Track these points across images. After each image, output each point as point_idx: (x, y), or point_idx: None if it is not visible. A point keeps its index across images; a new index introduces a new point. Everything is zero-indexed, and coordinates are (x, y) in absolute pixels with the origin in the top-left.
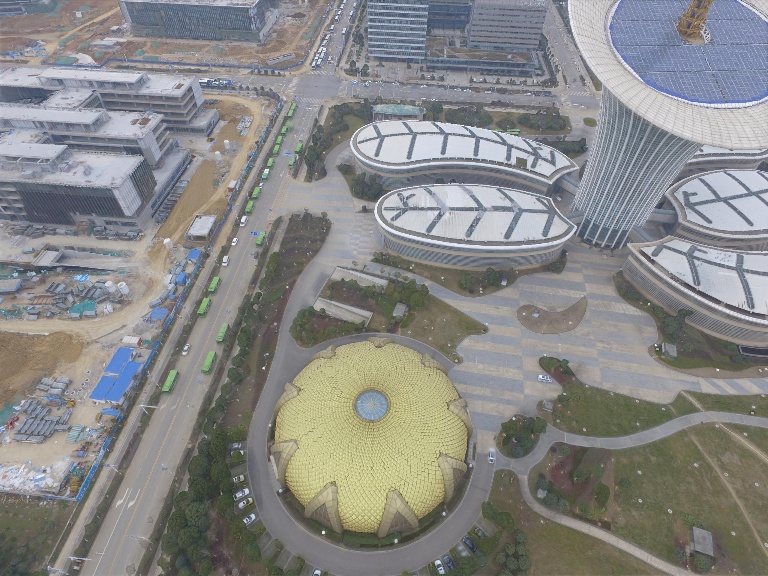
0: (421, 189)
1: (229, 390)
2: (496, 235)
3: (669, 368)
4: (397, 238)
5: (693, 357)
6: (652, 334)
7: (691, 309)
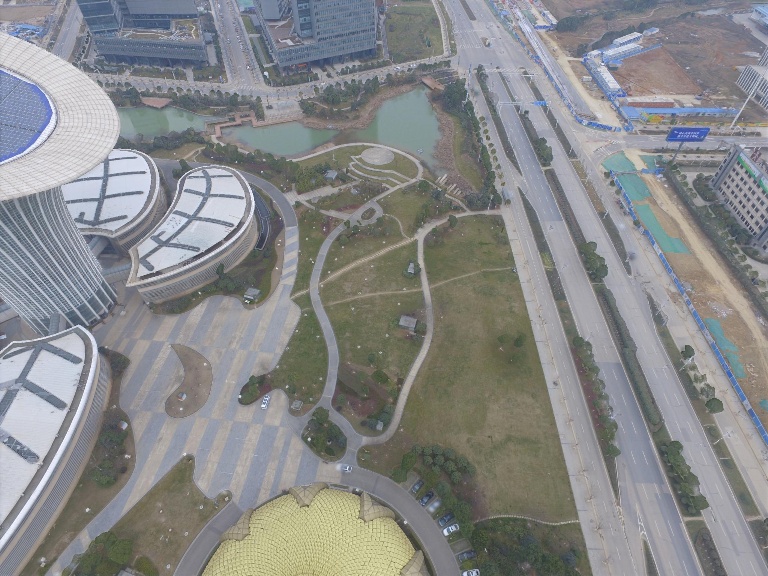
0: None
1: None
2: (53, 419)
3: (268, 300)
4: None
5: (261, 280)
6: (231, 301)
7: (216, 264)
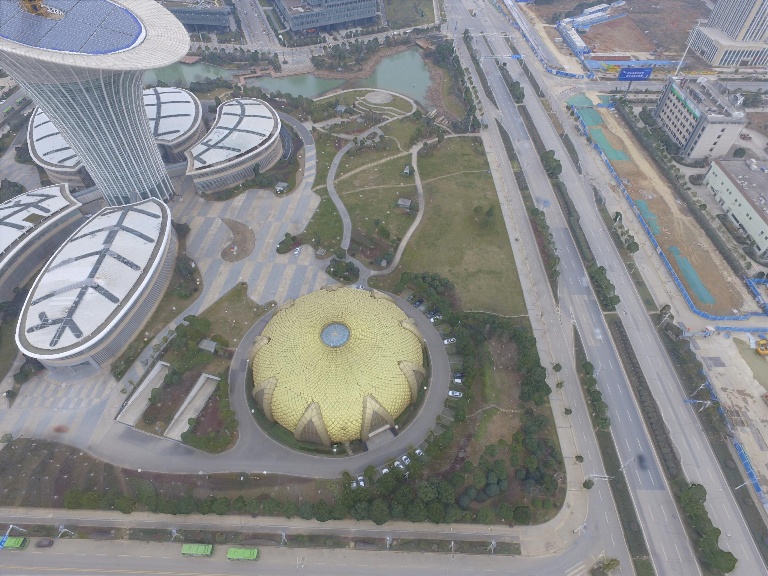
0: (33, 307)
1: (293, 503)
2: (146, 248)
3: (294, 191)
4: (106, 339)
5: (288, 179)
6: (265, 192)
7: (253, 165)
